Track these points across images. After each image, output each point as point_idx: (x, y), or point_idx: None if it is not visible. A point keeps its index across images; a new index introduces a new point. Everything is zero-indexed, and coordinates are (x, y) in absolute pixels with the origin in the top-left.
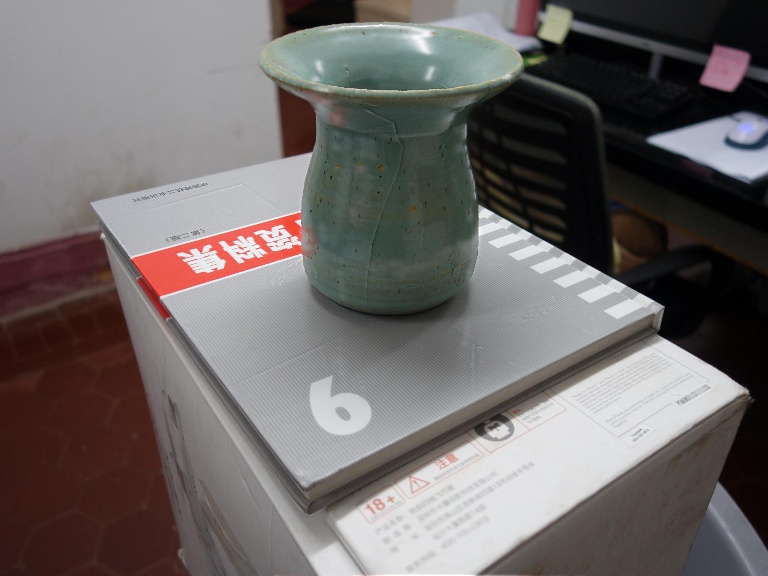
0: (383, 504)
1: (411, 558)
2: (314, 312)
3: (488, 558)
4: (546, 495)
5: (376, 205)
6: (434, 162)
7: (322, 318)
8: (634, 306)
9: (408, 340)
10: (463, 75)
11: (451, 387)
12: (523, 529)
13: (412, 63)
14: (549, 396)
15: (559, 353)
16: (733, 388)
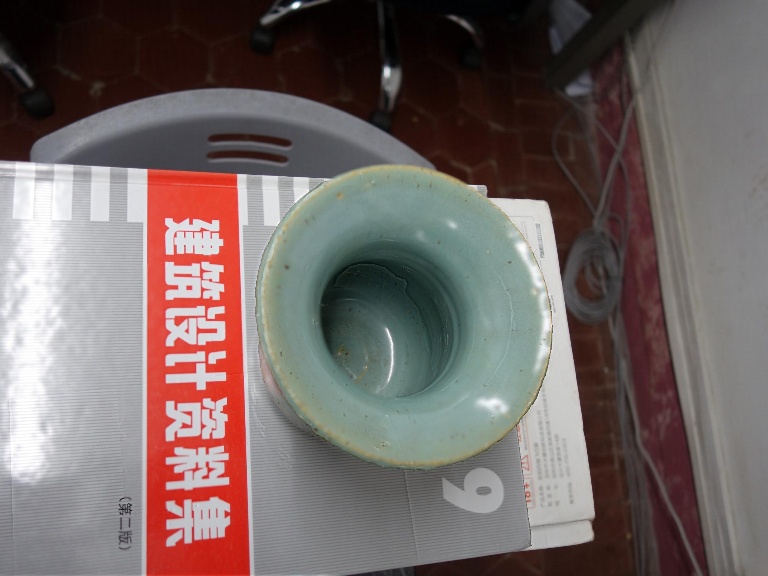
0: (528, 492)
1: (566, 497)
2: None
3: (585, 457)
4: (566, 395)
5: None
6: None
7: None
8: None
9: None
10: (414, 228)
11: None
12: (579, 425)
13: (342, 244)
14: None
15: None
16: (545, 211)
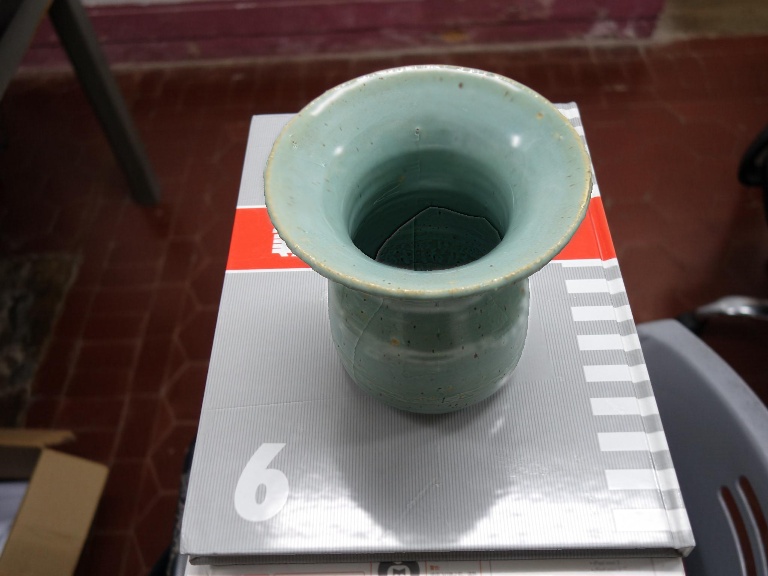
0: None
1: None
2: (329, 354)
3: None
4: None
5: (359, 321)
6: (424, 309)
7: (330, 366)
8: (657, 523)
9: (380, 437)
10: (527, 201)
11: (369, 520)
12: None
13: (497, 146)
14: (481, 569)
15: (508, 540)
16: None
